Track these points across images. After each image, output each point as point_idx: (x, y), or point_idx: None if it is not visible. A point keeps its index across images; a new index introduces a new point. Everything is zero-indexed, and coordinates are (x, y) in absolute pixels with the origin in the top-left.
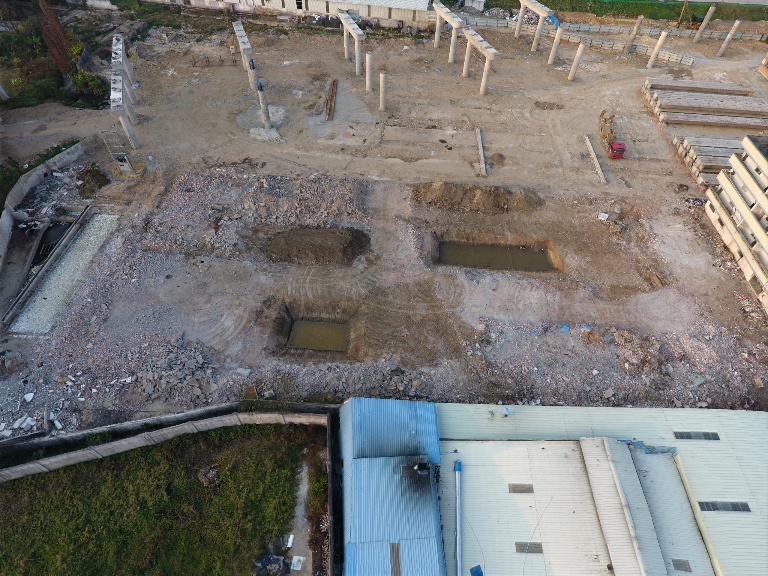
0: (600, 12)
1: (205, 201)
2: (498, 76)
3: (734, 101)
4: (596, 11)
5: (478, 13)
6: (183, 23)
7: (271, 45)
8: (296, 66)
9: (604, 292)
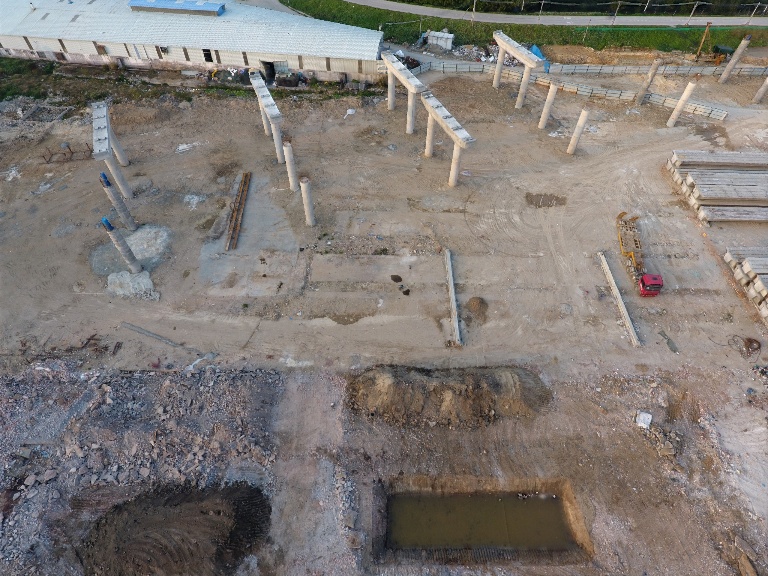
0: (598, 44)
1: (2, 442)
2: (473, 152)
3: None
4: (593, 43)
5: (445, 52)
6: (50, 89)
7: (165, 119)
8: (196, 152)
9: None
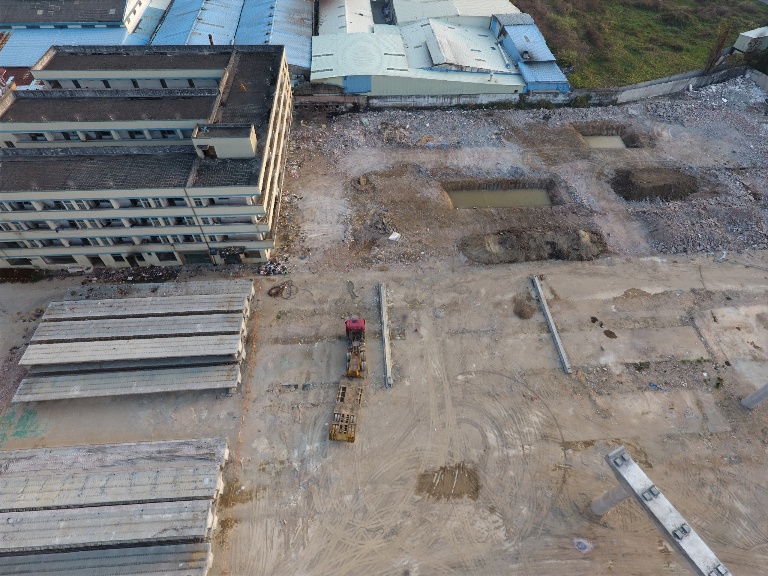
0: None
1: None
2: None
3: (24, 516)
4: None
5: None
6: None
7: None
8: None
9: (410, 171)
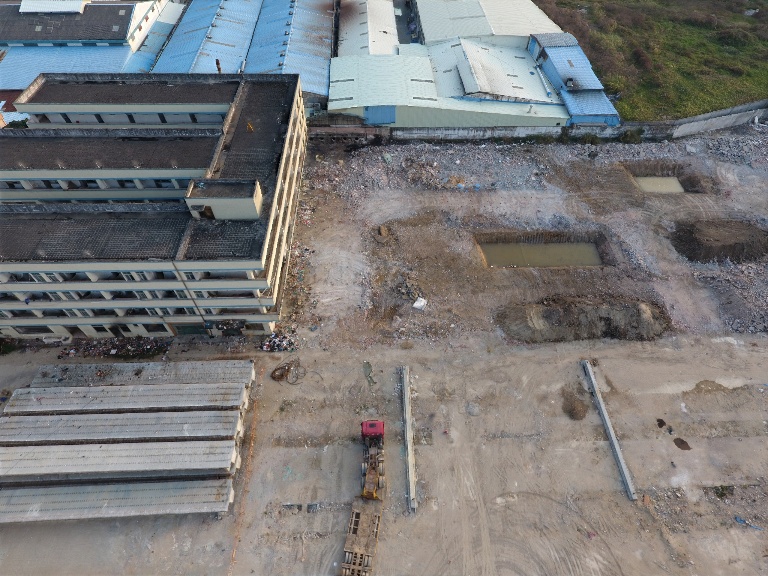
0: None
1: None
2: None
3: None
4: None
5: None
6: None
7: None
8: None
9: (438, 218)
